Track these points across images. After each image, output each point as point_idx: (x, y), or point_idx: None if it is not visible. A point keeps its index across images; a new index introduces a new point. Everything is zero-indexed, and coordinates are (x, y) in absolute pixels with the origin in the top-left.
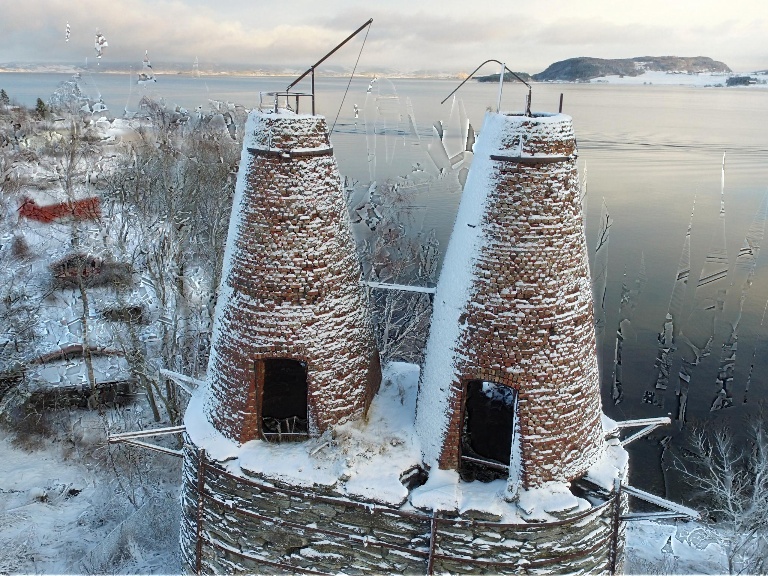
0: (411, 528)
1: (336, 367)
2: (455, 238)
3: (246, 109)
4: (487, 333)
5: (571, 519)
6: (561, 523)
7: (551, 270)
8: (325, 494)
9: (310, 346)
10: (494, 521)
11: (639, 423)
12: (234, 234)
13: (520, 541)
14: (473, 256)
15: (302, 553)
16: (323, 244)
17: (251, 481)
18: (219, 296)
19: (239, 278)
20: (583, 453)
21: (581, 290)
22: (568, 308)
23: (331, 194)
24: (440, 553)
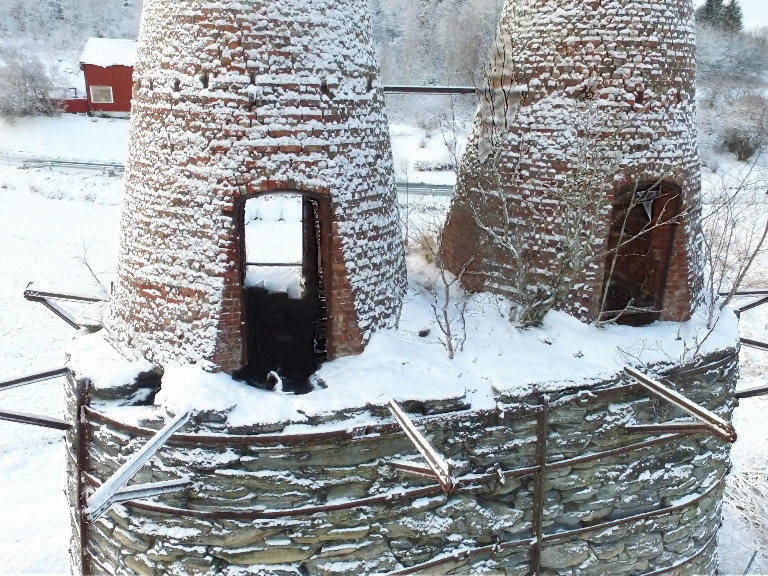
0: None
1: None
2: None
3: None
4: None
5: None
6: None
7: None
8: None
9: None
10: None
11: (6, 383)
12: None
13: None
14: None
15: None
16: None
17: None
18: None
19: None
20: None
21: None
22: None
23: None
24: None
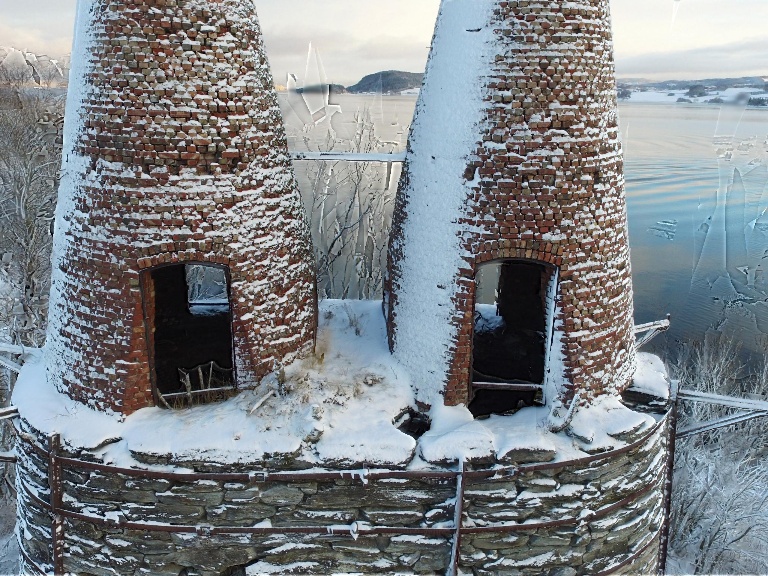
0: (424, 496)
1: (273, 275)
2: (444, 57)
3: (52, 59)
4: (511, 185)
5: (640, 440)
6: (630, 448)
7: (592, 87)
8: (283, 468)
9: (232, 241)
10: (546, 461)
11: (640, 329)
12: (83, 65)
13: (580, 484)
14: (481, 73)
15: (249, 573)
16: (239, 77)
17: (152, 470)
18: (62, 178)
19: (99, 135)
20: (629, 354)
21: (617, 126)
22: (610, 146)
23: (244, 2)
24: (470, 525)
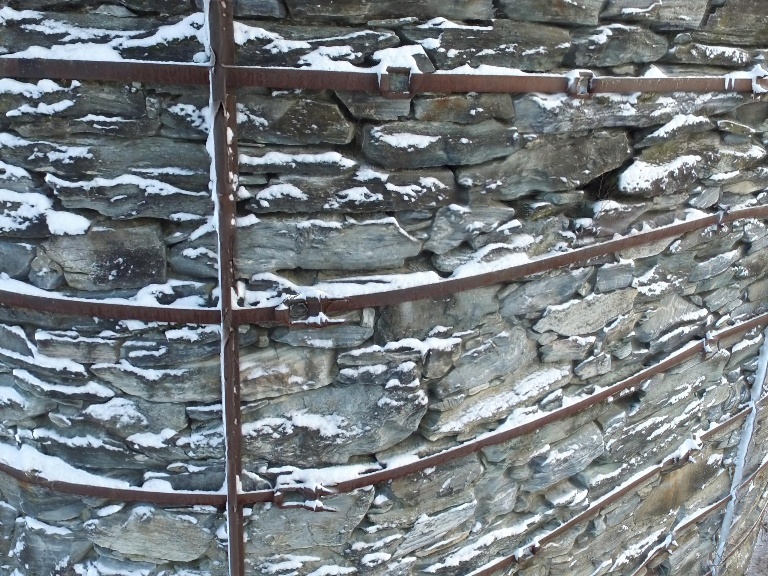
0: None
1: None
2: None
3: None
4: None
5: None
6: None
7: None
8: None
9: None
10: None
11: None
12: None
13: None
14: None
15: (626, 184)
16: None
17: None
18: None
19: None
20: None
21: None
22: None
23: None
24: None
